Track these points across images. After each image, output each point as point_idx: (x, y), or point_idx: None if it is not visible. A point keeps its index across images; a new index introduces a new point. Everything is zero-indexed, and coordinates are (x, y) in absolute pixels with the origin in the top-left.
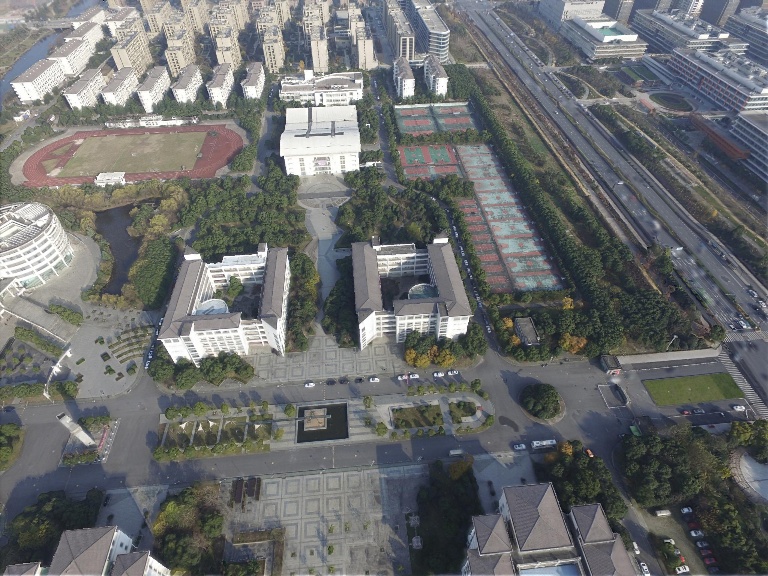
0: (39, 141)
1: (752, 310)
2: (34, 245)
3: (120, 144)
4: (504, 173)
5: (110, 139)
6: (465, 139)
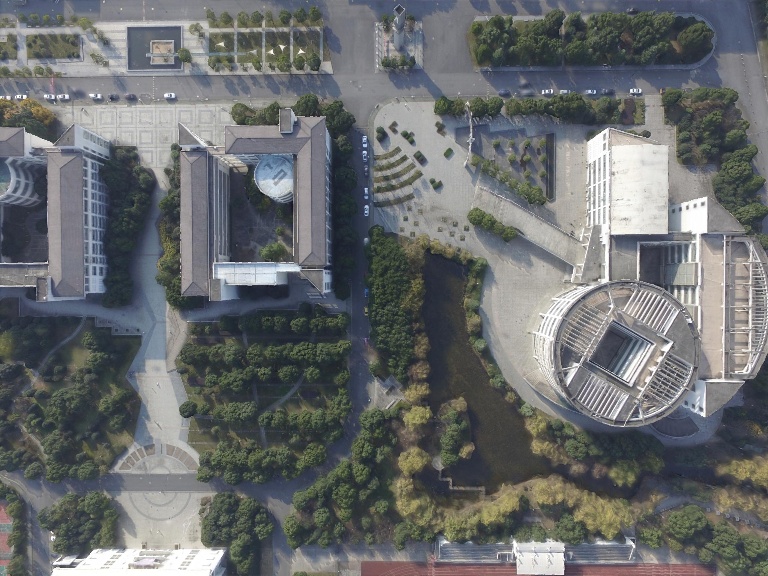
0: None
1: None
2: None
3: None
4: None
5: None
6: None
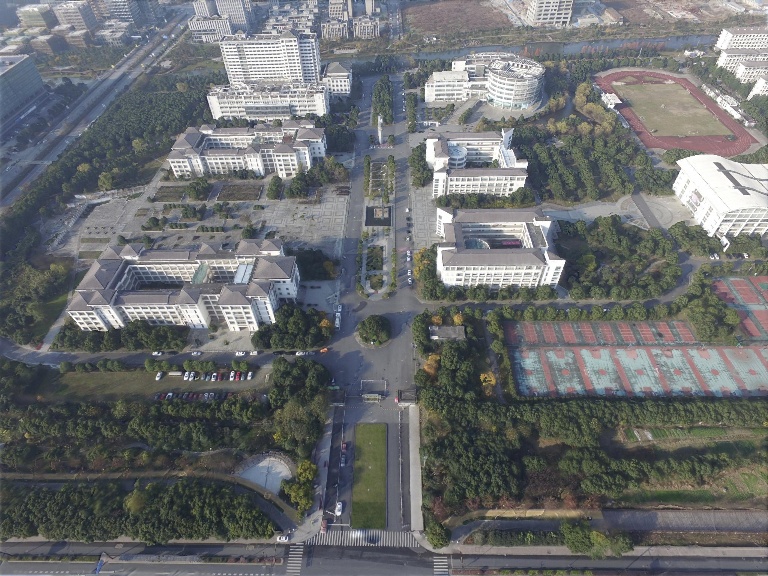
0: (659, 68)
1: None
2: (506, 82)
3: (677, 98)
4: None
5: (683, 93)
6: None
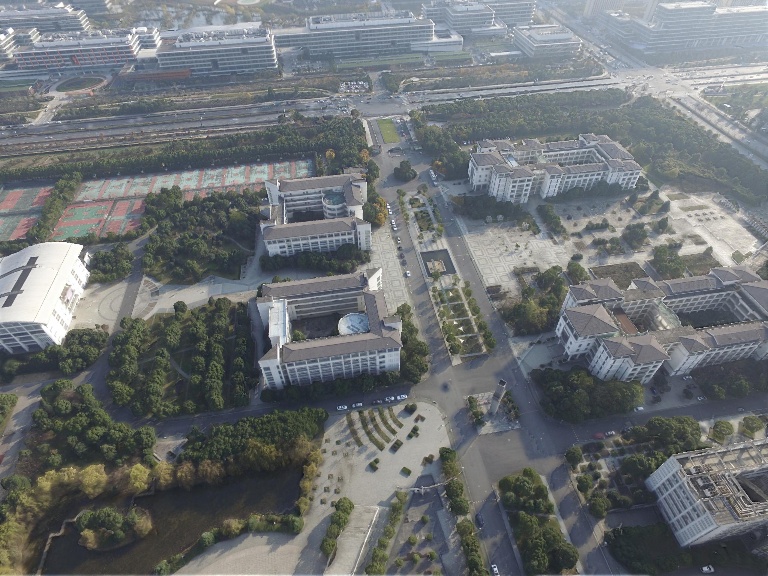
0: None
1: (333, 105)
2: None
3: None
4: (149, 174)
5: None
6: (70, 191)
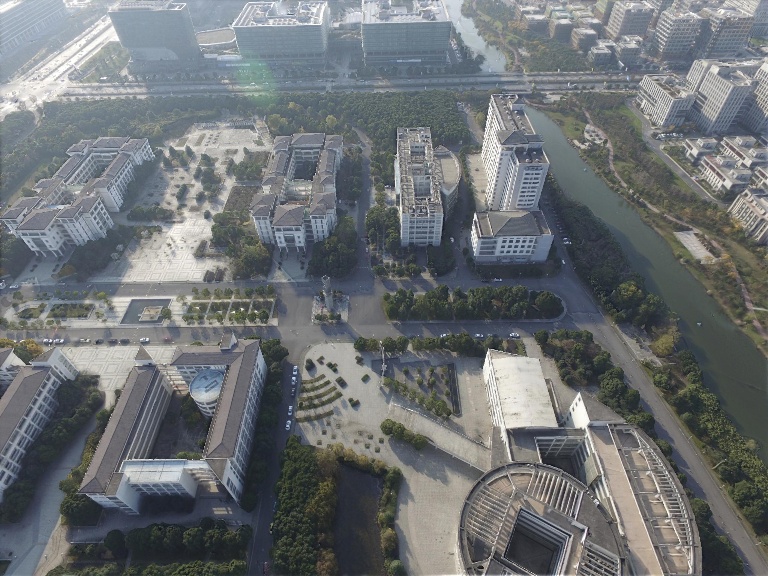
0: None
1: None
2: None
3: None
4: None
5: None
6: None
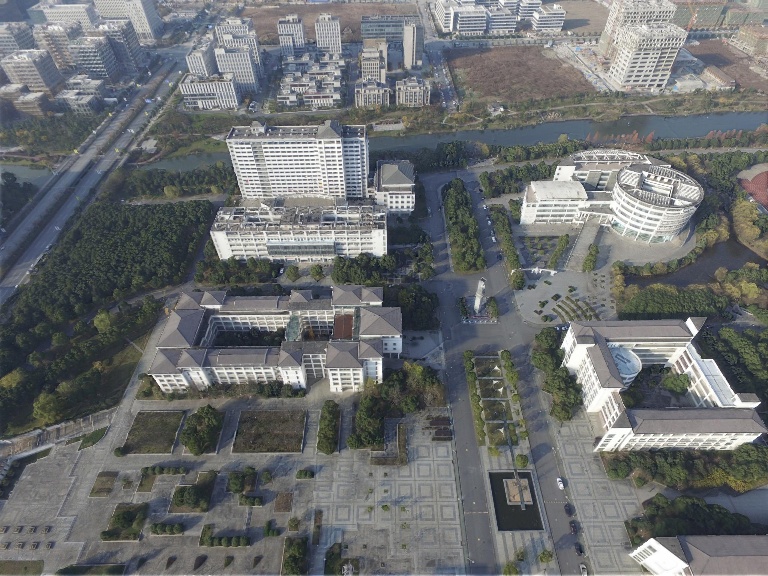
0: None
1: None
2: (650, 209)
3: None
4: None
5: None
6: None
